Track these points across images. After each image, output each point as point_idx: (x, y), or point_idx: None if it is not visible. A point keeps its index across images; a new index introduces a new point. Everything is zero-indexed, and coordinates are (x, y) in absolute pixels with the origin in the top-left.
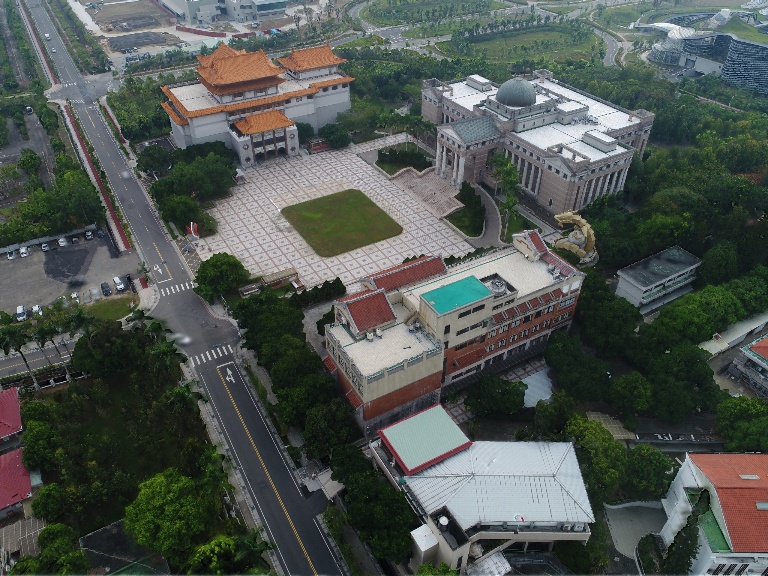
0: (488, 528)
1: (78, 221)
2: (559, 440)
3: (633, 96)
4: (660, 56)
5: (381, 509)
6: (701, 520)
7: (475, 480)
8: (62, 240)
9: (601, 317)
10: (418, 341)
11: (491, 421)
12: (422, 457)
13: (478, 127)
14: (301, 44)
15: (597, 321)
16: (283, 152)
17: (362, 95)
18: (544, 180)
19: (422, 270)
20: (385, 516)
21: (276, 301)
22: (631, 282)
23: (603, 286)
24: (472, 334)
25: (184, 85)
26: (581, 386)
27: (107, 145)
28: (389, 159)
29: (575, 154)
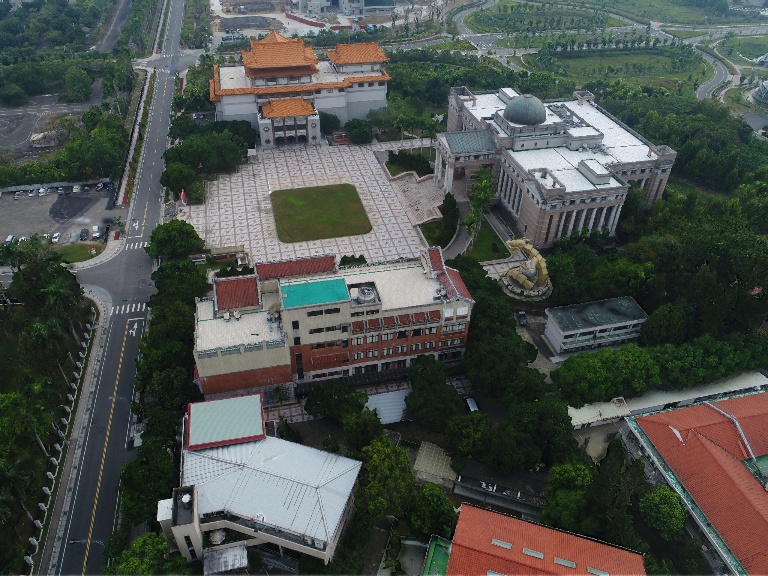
0: (238, 519)
1: (94, 173)
2: (354, 457)
3: (689, 132)
4: (766, 95)
5: (142, 472)
6: (431, 572)
7: (242, 471)
8: (76, 187)
9: (478, 349)
10: (269, 330)
11: (333, 427)
12: (209, 437)
13: (474, 140)
14: (389, 41)
15: (474, 352)
16: (306, 140)
17: (410, 96)
18: (523, 204)
19: (310, 265)
20: (142, 479)
21: (191, 270)
22: (554, 323)
23: (507, 320)
24: (330, 336)
25: (235, 66)
26: (420, 413)
27: (164, 112)
28: (398, 161)
29: (555, 181)
